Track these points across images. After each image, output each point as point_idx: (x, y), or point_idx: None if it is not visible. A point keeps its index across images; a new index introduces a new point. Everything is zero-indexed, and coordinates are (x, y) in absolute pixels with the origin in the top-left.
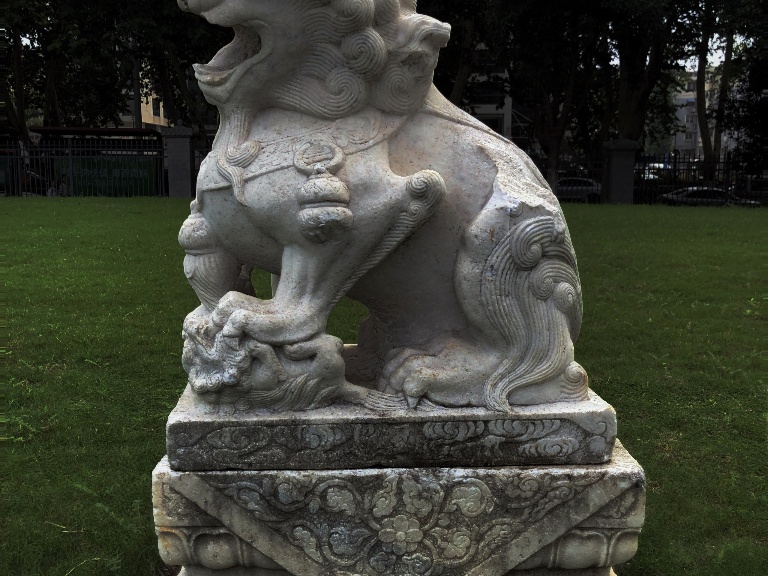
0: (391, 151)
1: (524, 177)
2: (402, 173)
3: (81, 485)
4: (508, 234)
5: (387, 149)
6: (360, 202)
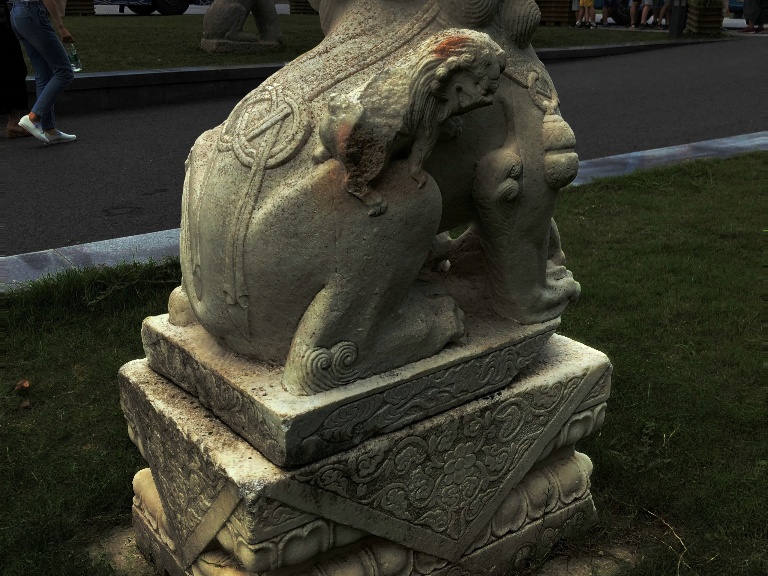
0: None
1: None
2: None
3: (765, 465)
4: None
5: None
6: None
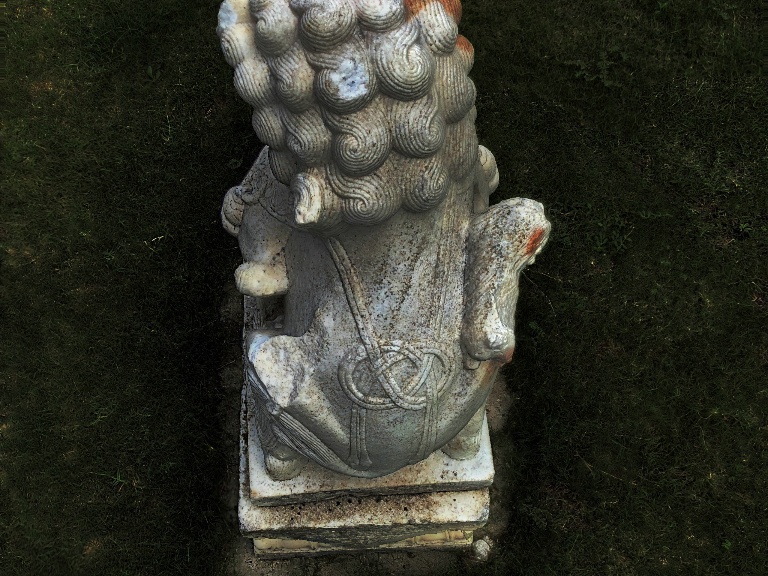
0: (293, 235)
1: (312, 365)
2: (288, 254)
3: None
4: (247, 362)
5: (289, 230)
6: (243, 234)
